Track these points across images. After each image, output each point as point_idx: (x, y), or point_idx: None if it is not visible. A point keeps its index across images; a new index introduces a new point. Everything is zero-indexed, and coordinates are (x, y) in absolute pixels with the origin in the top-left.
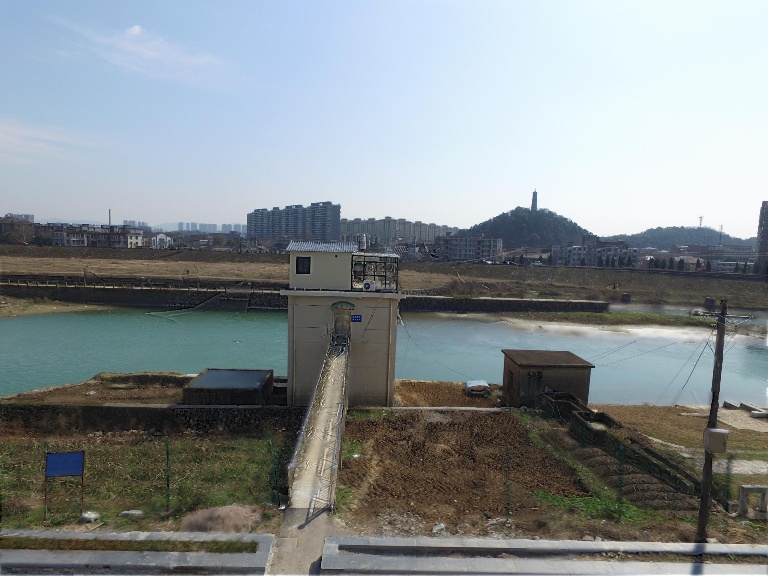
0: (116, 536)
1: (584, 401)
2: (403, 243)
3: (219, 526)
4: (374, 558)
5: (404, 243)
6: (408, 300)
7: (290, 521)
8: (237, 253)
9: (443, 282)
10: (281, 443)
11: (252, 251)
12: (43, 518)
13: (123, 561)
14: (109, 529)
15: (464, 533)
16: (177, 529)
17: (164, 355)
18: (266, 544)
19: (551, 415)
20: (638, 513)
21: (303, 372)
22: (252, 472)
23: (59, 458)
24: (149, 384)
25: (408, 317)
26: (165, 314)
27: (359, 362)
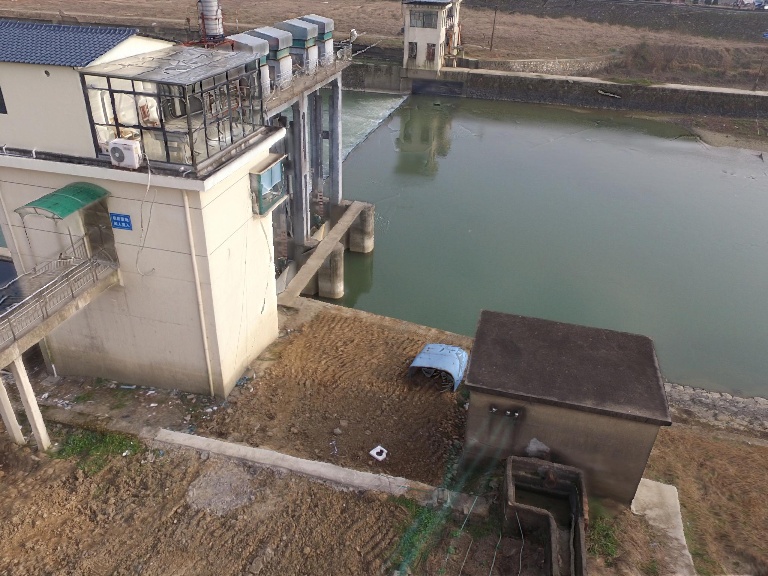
0: None
1: (629, 484)
2: None
3: None
4: None
5: None
6: (530, 83)
7: None
8: None
9: (620, 45)
10: None
11: None
12: None
13: None
14: None
15: None
16: None
17: None
18: None
19: (500, 529)
20: None
21: None
22: None
23: None
24: None
25: (519, 116)
26: None
27: (146, 308)
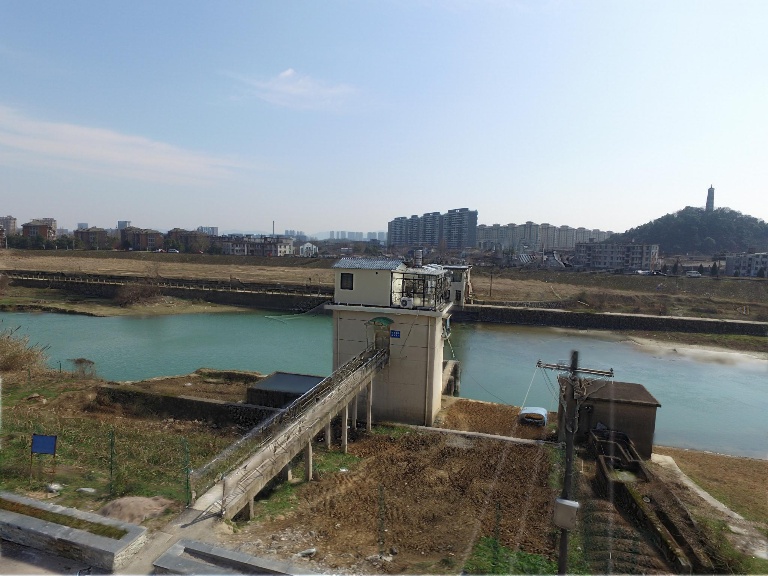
0: (43, 506)
1: (648, 445)
2: (529, 251)
3: (116, 512)
4: (200, 565)
5: (530, 251)
6: (520, 313)
7: (180, 519)
8: None
9: (569, 294)
10: None
11: None
12: (28, 483)
13: (30, 526)
14: (58, 500)
15: (323, 562)
16: (97, 509)
17: (269, 355)
18: (133, 534)
19: (594, 456)
20: None
21: None
22: None
23: (40, 439)
24: (235, 381)
25: (517, 331)
26: (280, 318)
27: (398, 377)
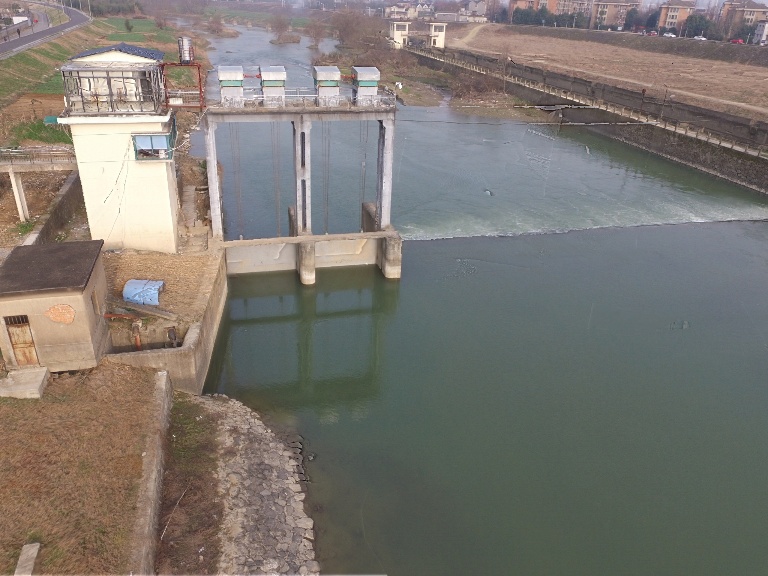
0: None
1: None
2: None
3: None
4: None
5: None
6: None
7: None
8: None
9: None
10: None
11: None
12: None
13: None
14: None
15: None
16: None
17: None
18: None
19: None
20: None
21: None
22: None
23: None
24: None
25: None
26: (481, 137)
27: None
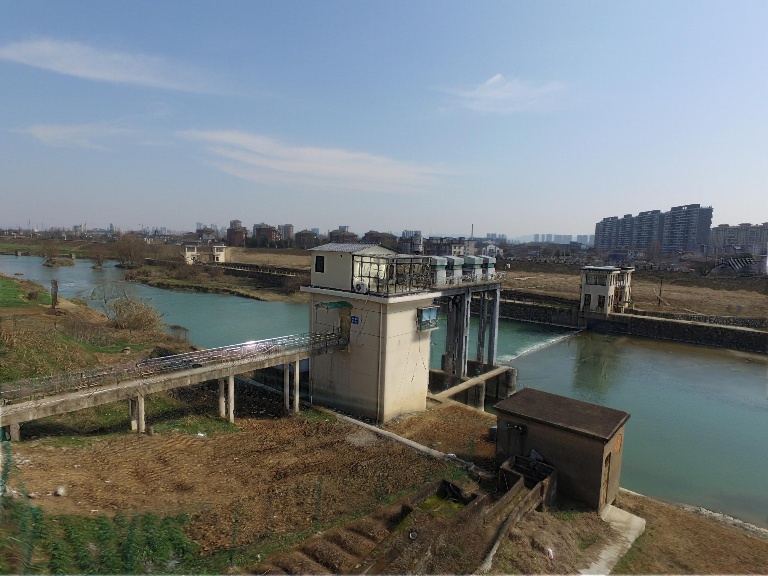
0: None
1: (594, 492)
2: (744, 253)
3: None
4: None
5: (745, 253)
6: (685, 327)
7: None
8: (535, 263)
9: None
10: (180, 407)
11: (550, 261)
12: None
13: None
14: None
15: None
16: None
17: None
18: None
19: (496, 486)
20: (144, 572)
21: (318, 366)
22: (121, 416)
23: None
24: None
25: (672, 349)
26: None
27: (357, 366)
